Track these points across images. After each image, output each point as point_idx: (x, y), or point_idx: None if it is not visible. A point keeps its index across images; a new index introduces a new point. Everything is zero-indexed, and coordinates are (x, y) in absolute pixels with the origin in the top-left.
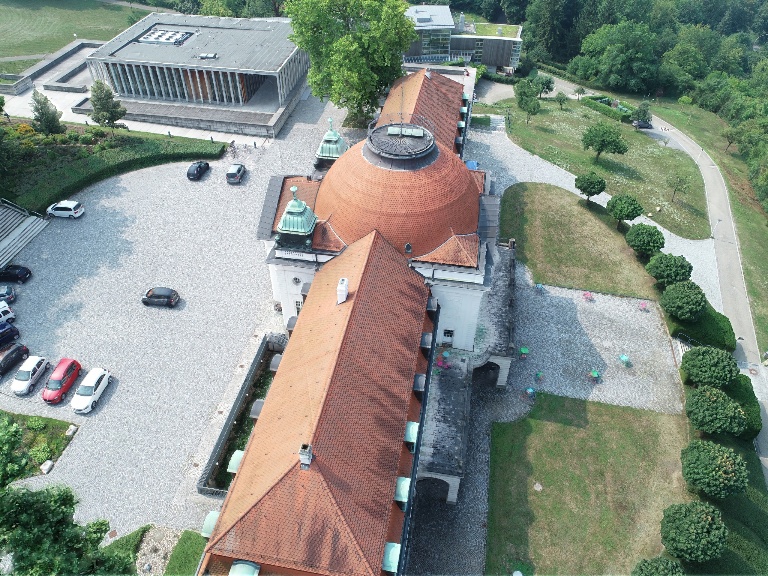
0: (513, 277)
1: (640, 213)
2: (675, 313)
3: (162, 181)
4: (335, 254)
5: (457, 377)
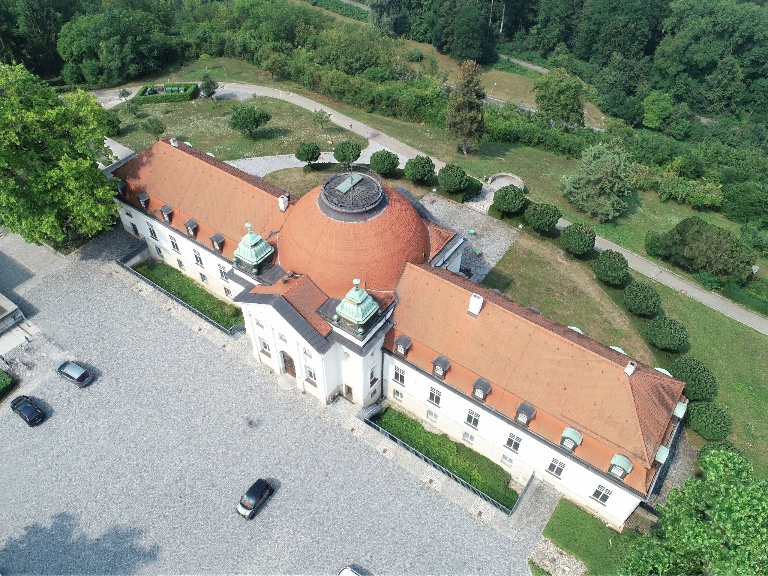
0: None
1: (360, 149)
2: (459, 188)
3: (7, 458)
4: (395, 303)
5: None
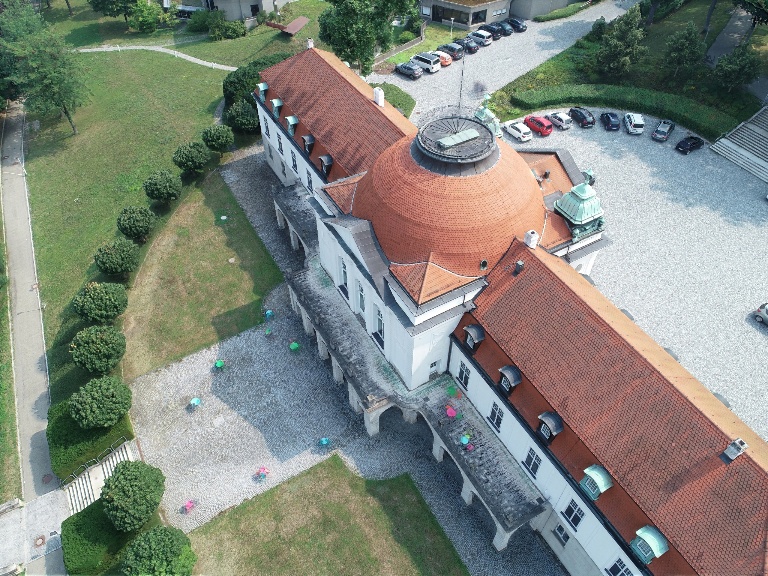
0: (333, 340)
1: None
2: None
3: None
4: None
5: (317, 239)
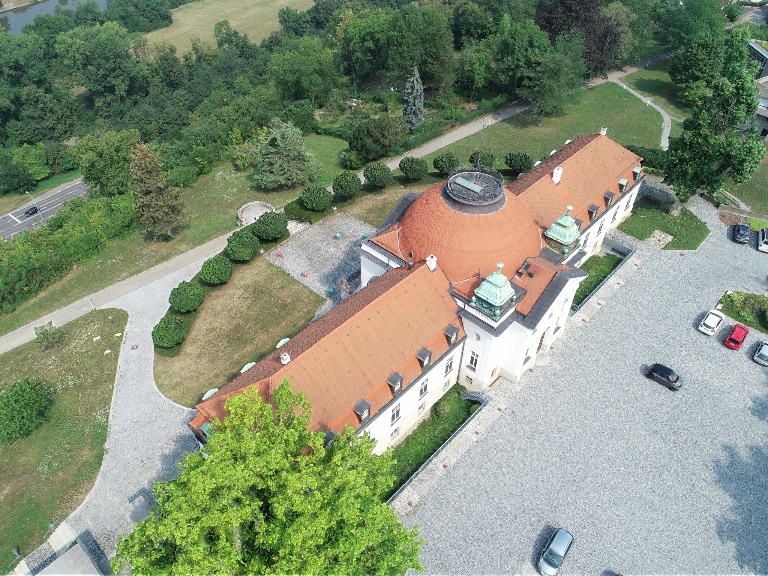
0: None
1: None
2: None
3: None
4: None
5: None
